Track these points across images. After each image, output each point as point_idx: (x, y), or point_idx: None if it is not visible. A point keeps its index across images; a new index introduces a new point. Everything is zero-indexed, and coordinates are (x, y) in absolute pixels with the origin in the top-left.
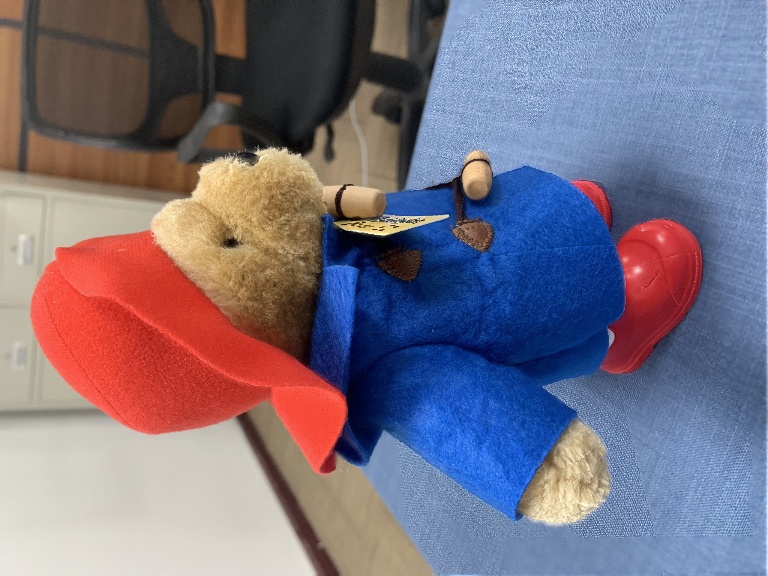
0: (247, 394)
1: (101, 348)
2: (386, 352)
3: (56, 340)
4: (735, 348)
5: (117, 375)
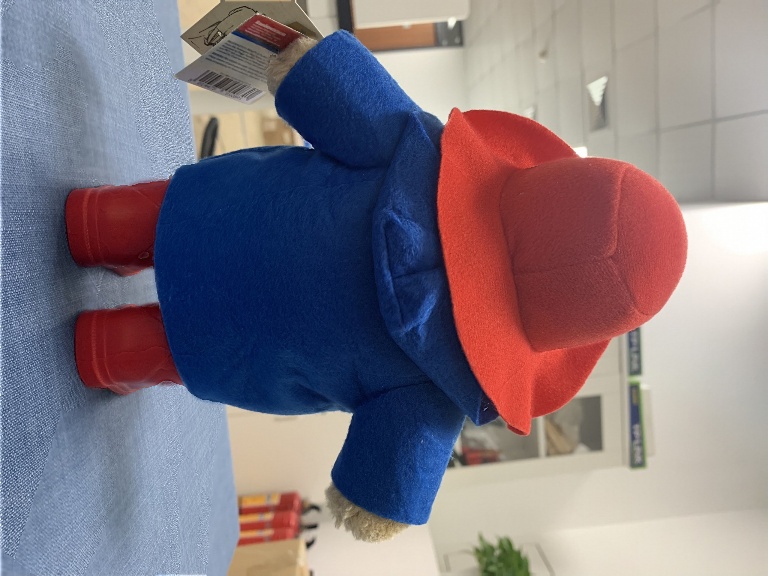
0: (550, 346)
1: None
2: None
3: None
4: None
5: None
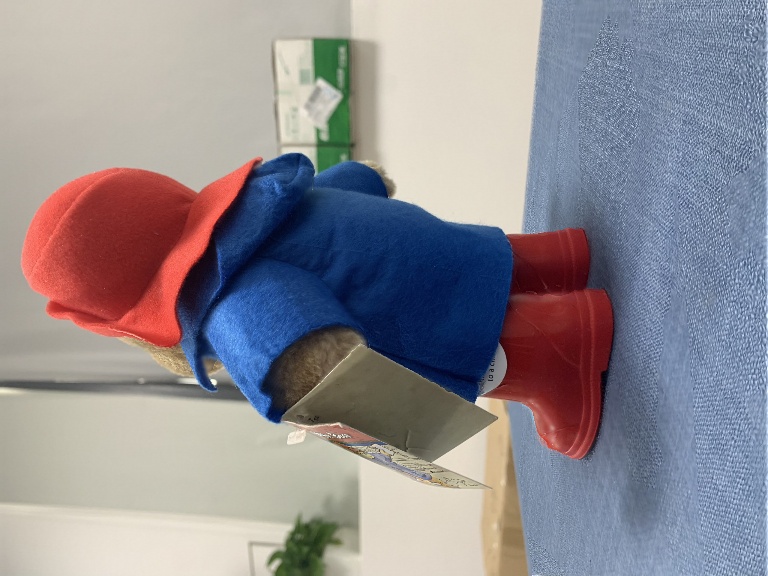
0: None
1: None
2: None
3: None
4: None
5: None
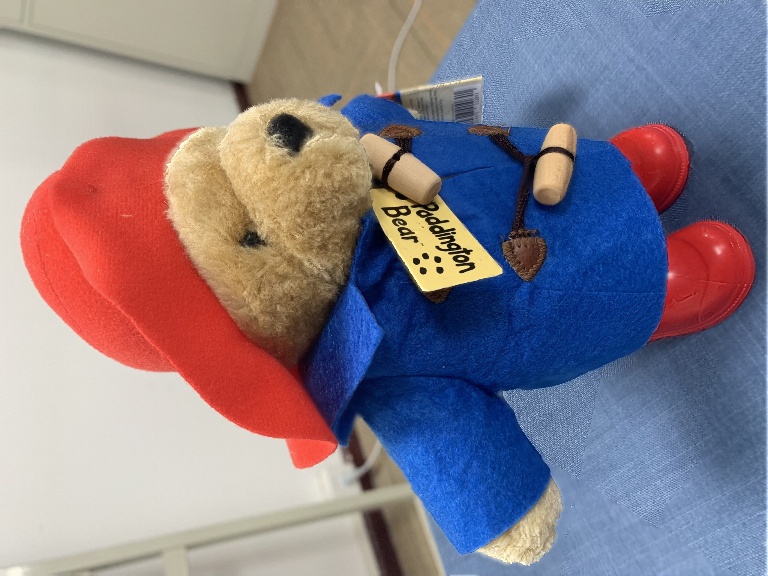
0: None
1: (97, 319)
2: (391, 375)
3: (49, 293)
4: (729, 388)
5: (113, 342)
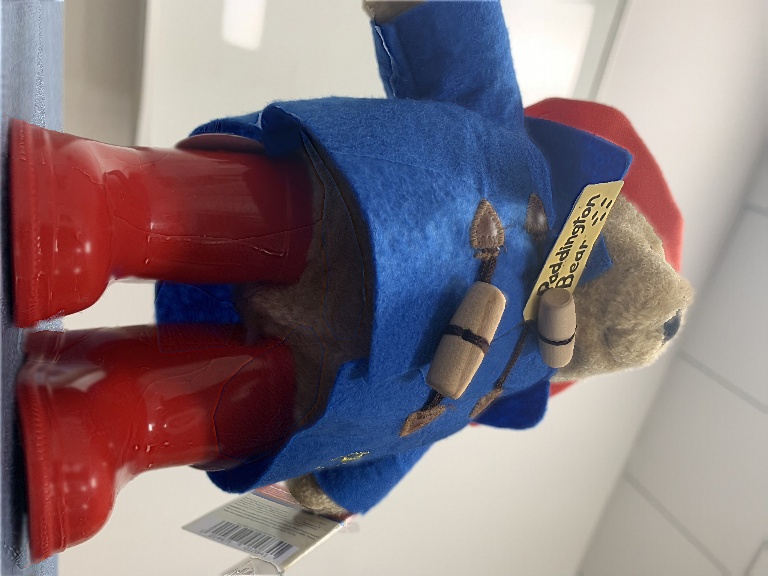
0: None
1: None
2: None
3: None
4: None
5: None
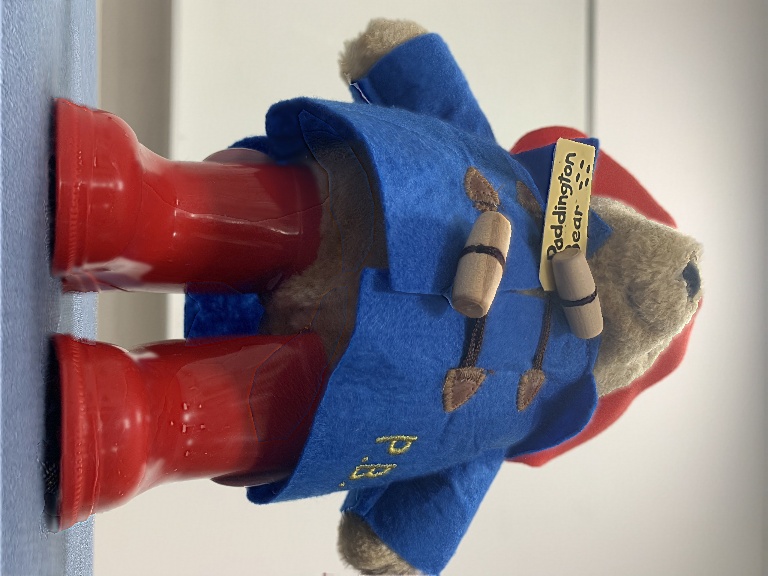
0: None
1: None
2: None
3: None
4: None
5: None
